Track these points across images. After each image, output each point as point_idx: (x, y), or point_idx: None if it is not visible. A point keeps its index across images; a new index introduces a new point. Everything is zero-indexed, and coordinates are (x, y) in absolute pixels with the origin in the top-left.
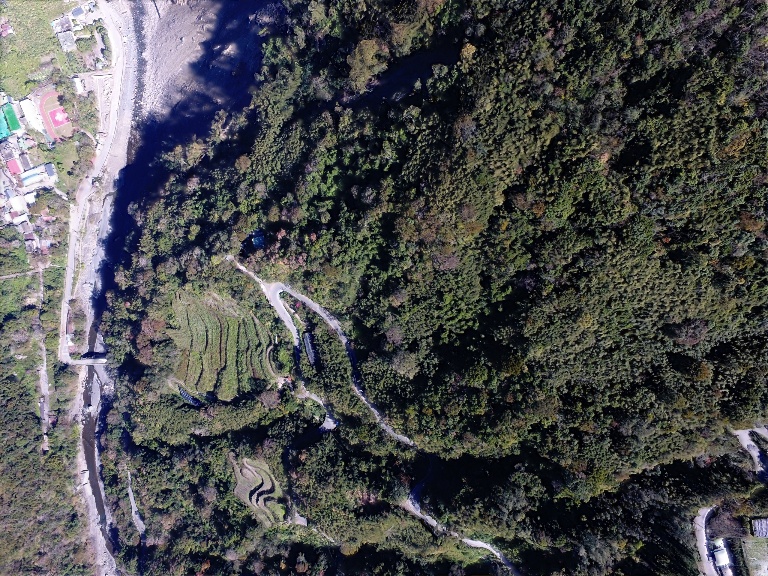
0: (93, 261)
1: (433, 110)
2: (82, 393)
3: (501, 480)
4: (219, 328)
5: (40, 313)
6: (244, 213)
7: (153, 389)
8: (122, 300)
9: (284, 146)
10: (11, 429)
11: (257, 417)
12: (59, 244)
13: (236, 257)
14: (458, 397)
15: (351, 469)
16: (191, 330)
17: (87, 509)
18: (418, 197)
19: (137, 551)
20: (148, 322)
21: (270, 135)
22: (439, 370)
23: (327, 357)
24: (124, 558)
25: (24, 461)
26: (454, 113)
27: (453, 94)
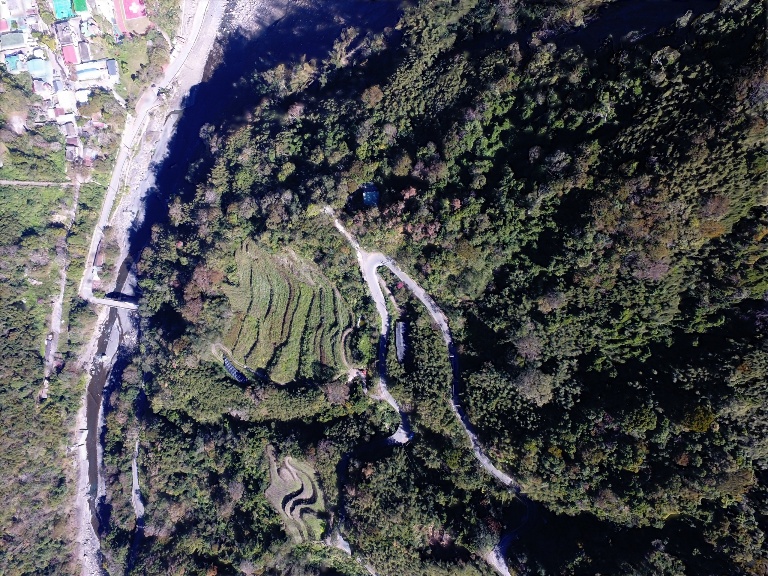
0: (140, 186)
1: (700, 58)
2: (97, 338)
3: (632, 556)
4: (288, 294)
5: (68, 234)
6: (360, 158)
7: (194, 352)
8: (174, 238)
9: (437, 82)
10: (8, 366)
11: (316, 411)
12: (106, 158)
13: (337, 211)
14: (605, 443)
15: (425, 498)
16: (252, 290)
17: (77, 475)
18: (639, 174)
19: (130, 538)
20: (204, 270)
21: (419, 65)
22: (580, 403)
23: (425, 357)
24: (113, 543)
25: (16, 407)
26: (734, 66)
27: (737, 40)
